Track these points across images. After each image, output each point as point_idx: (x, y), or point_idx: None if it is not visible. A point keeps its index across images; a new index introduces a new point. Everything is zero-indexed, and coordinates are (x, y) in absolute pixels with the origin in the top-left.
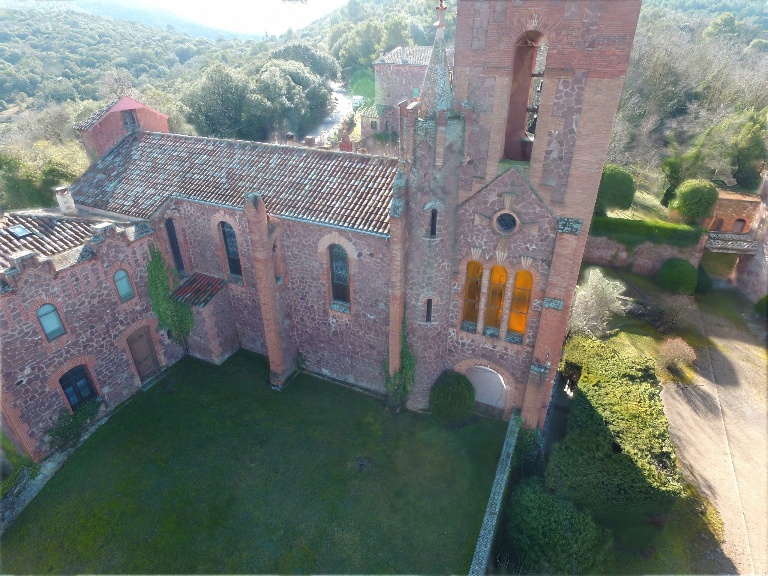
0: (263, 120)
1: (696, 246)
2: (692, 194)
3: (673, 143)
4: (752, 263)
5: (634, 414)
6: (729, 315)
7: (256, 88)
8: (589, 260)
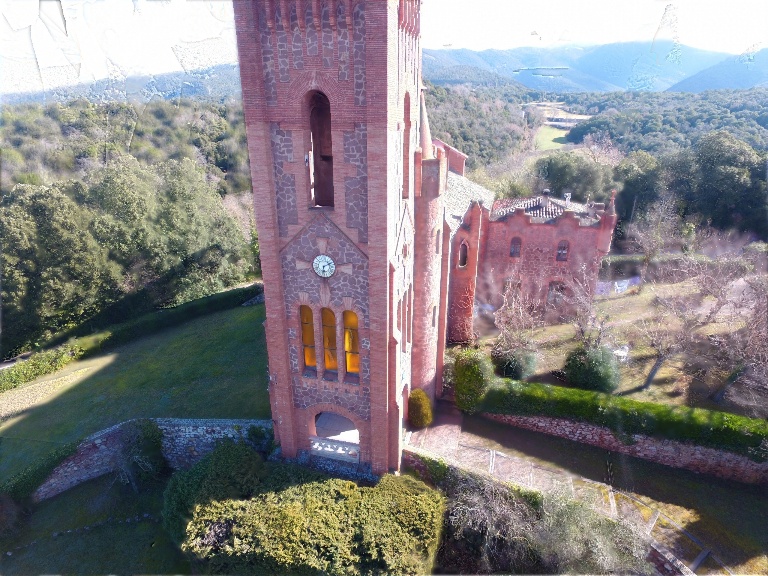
0: (726, 197)
1: None
2: None
3: None
4: None
5: (287, 517)
6: None
7: (759, 162)
8: None
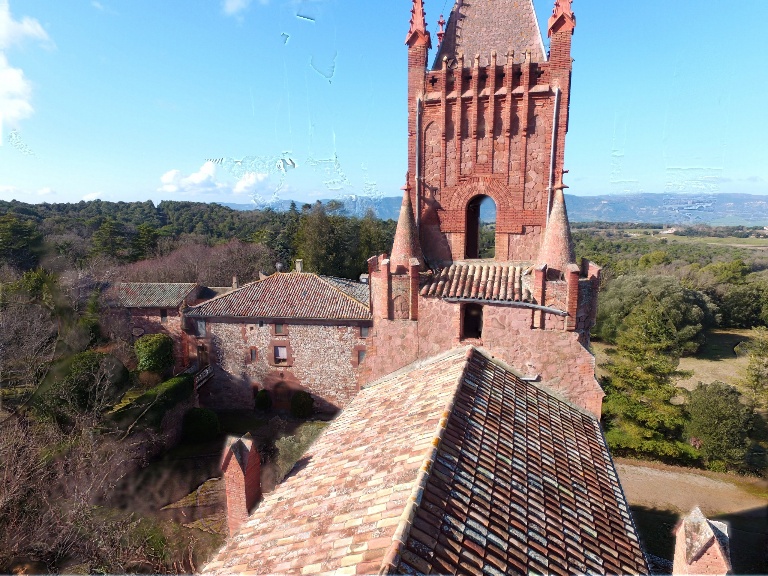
0: None
1: (193, 390)
2: (163, 348)
3: (85, 313)
4: (214, 383)
5: None
6: (255, 424)
7: None
8: (130, 472)
